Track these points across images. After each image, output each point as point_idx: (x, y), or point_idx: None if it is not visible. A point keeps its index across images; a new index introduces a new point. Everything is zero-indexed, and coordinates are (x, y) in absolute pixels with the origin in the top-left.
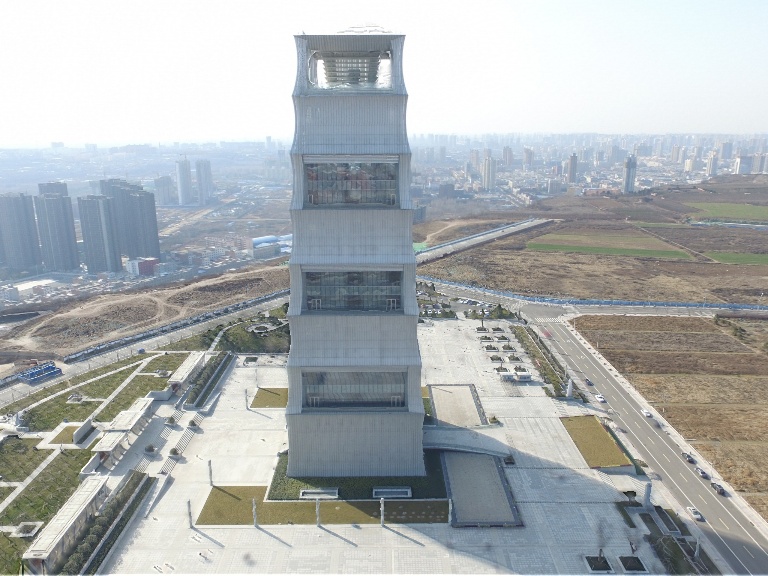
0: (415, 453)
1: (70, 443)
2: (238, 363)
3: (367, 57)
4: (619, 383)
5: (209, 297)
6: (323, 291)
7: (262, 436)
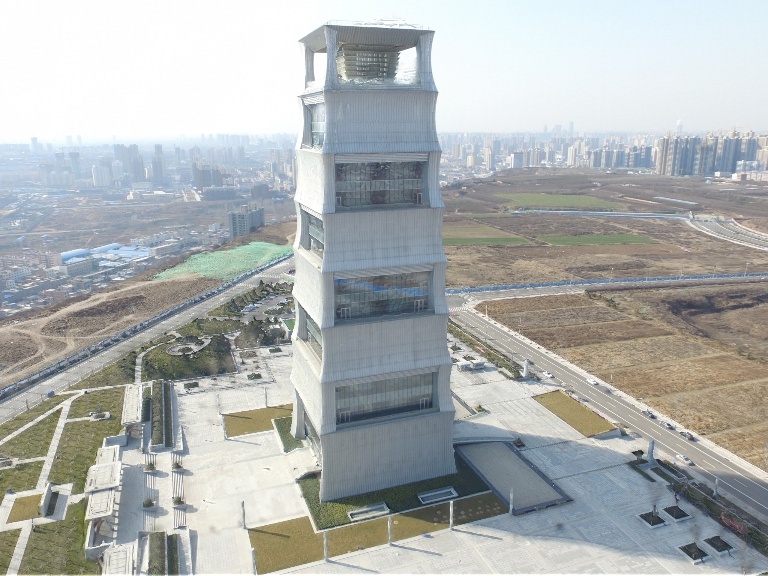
0: (446, 452)
1: (37, 517)
2: (179, 391)
3: (388, 52)
4: (553, 359)
5: (91, 322)
6: (352, 298)
7: (263, 465)
